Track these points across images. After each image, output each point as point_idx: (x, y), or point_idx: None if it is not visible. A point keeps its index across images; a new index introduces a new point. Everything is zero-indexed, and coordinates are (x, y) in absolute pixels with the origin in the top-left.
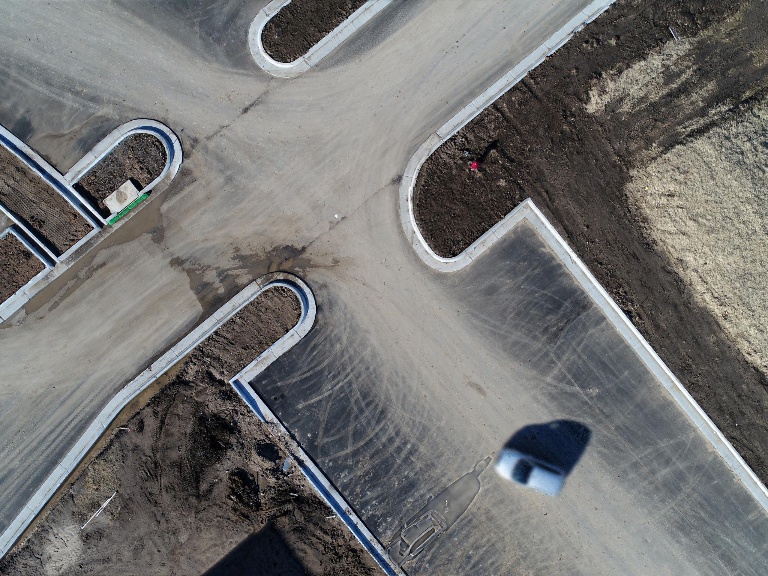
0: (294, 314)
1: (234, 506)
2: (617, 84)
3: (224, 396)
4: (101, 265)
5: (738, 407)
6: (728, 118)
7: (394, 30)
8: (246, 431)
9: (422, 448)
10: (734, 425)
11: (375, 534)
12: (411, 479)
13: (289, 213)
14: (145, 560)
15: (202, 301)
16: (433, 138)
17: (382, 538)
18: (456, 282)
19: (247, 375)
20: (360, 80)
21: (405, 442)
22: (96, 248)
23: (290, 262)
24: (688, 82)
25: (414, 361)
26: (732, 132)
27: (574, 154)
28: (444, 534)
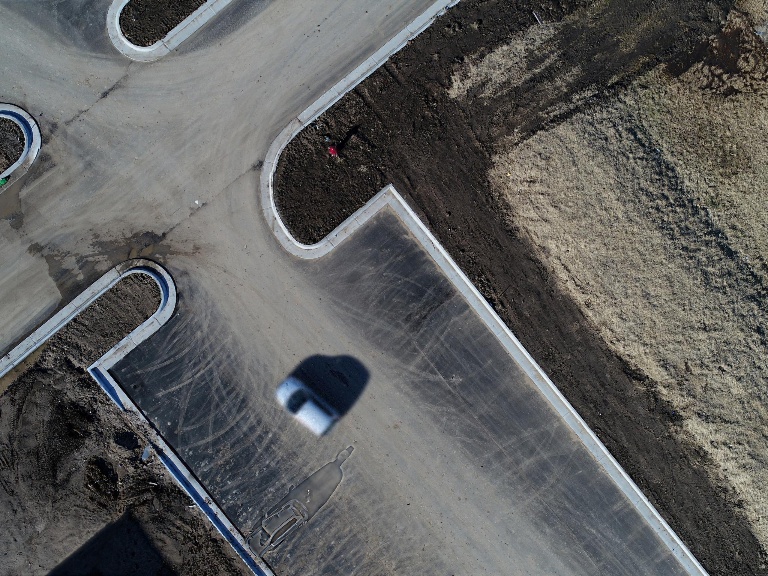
0: (154, 301)
1: (92, 495)
2: (479, 69)
3: (82, 384)
4: None
5: (602, 396)
6: (592, 104)
7: (255, 14)
8: (105, 419)
9: (284, 437)
10: (598, 414)
11: (235, 524)
12: (272, 468)
13: (149, 199)
14: (1, 549)
15: (61, 288)
16: (294, 123)
17: (242, 528)
18: (318, 269)
19: (106, 363)
20: (220, 64)
21: (266, 431)
22: None
23: (150, 249)
24: (552, 67)
25: (276, 349)
26: (596, 118)
27: (436, 140)
28: (306, 524)
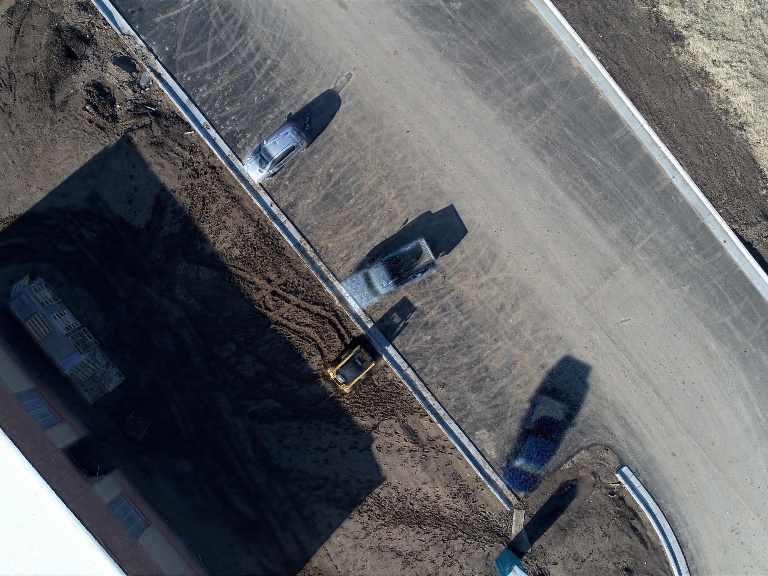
0: None
1: (90, 118)
2: None
3: (79, 7)
4: None
5: (603, 17)
6: None
7: None
8: (103, 44)
9: (282, 64)
10: (598, 36)
11: (234, 150)
12: (271, 95)
13: None
14: None
15: None
16: None
17: (241, 154)
18: None
19: None
20: None
21: (265, 58)
22: None
23: None
24: None
25: None
26: None
27: None
28: (304, 151)
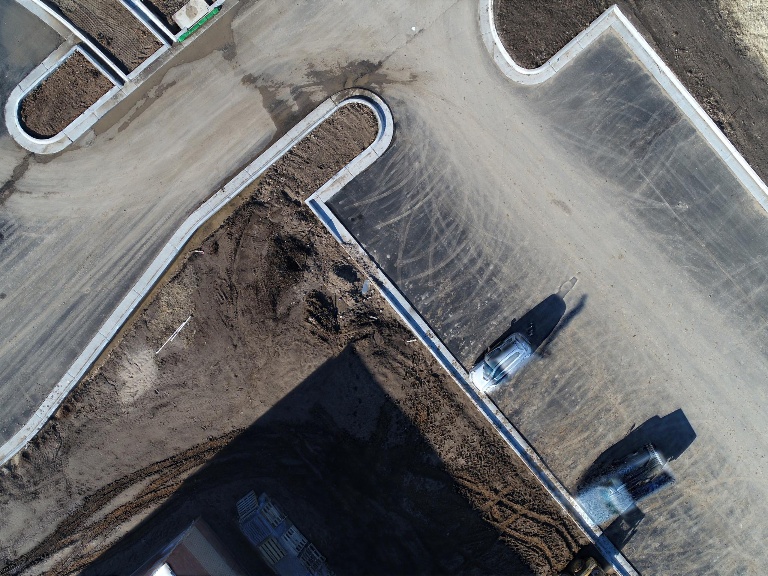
0: (371, 131)
1: (312, 329)
2: None
3: (300, 216)
4: (171, 84)
5: None
6: None
7: None
8: (323, 253)
9: (505, 269)
10: None
11: (458, 358)
12: (494, 301)
13: (364, 26)
14: (222, 385)
15: (276, 119)
16: None
17: (465, 362)
18: (539, 96)
19: (323, 195)
20: None
21: (487, 263)
22: (165, 66)
23: (366, 78)
24: None
25: (496, 179)
26: None
27: None
28: (529, 358)
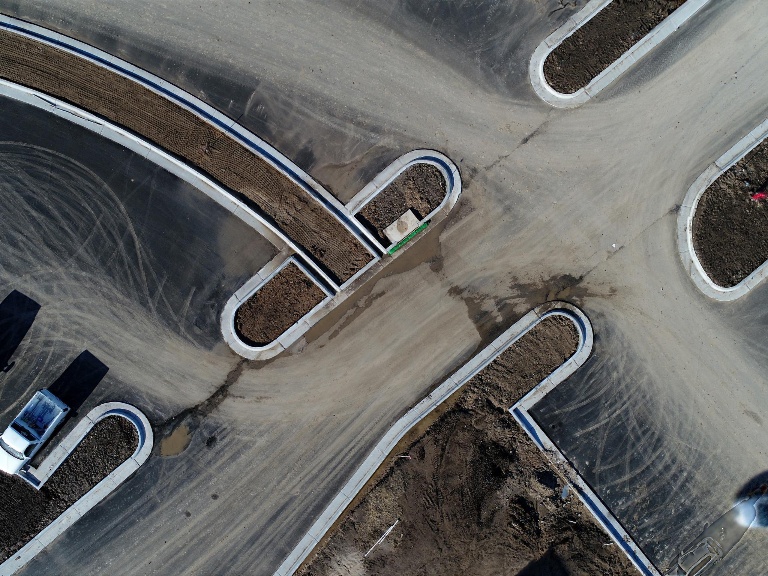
0: (572, 343)
1: (515, 534)
2: None
3: (504, 424)
4: (380, 294)
5: None
6: None
7: (673, 61)
8: (524, 459)
9: (698, 476)
10: None
11: (653, 561)
12: (687, 507)
13: (567, 242)
14: None
15: (480, 330)
16: (712, 168)
17: (659, 565)
18: (733, 311)
19: (526, 403)
20: (639, 111)
21: (681, 470)
22: (375, 277)
23: (567, 291)
24: None
25: (690, 389)
26: None
27: None
28: (720, 561)
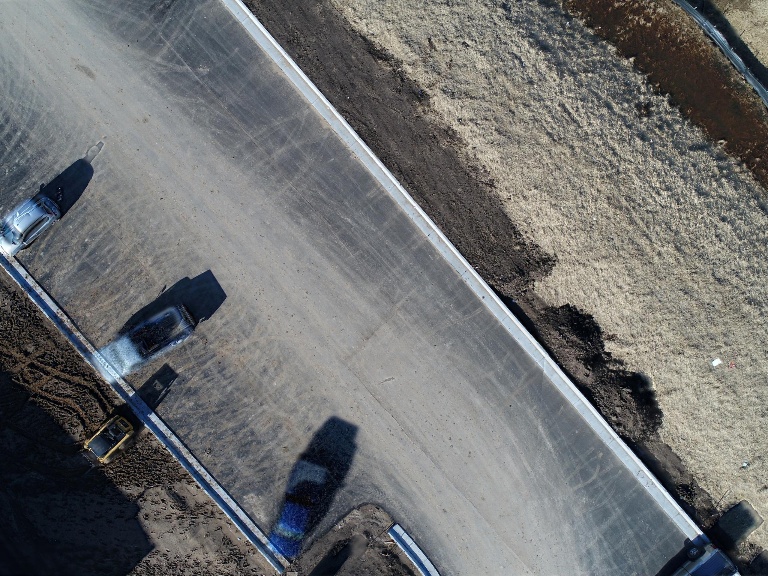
0: None
1: None
2: None
3: None
4: None
5: (348, 79)
6: None
7: None
8: None
9: (32, 135)
10: (345, 98)
11: None
12: (22, 167)
13: None
14: None
15: None
16: None
17: None
18: None
19: None
20: None
21: (15, 129)
22: None
23: None
24: None
25: (20, 45)
26: None
27: None
28: (58, 222)
